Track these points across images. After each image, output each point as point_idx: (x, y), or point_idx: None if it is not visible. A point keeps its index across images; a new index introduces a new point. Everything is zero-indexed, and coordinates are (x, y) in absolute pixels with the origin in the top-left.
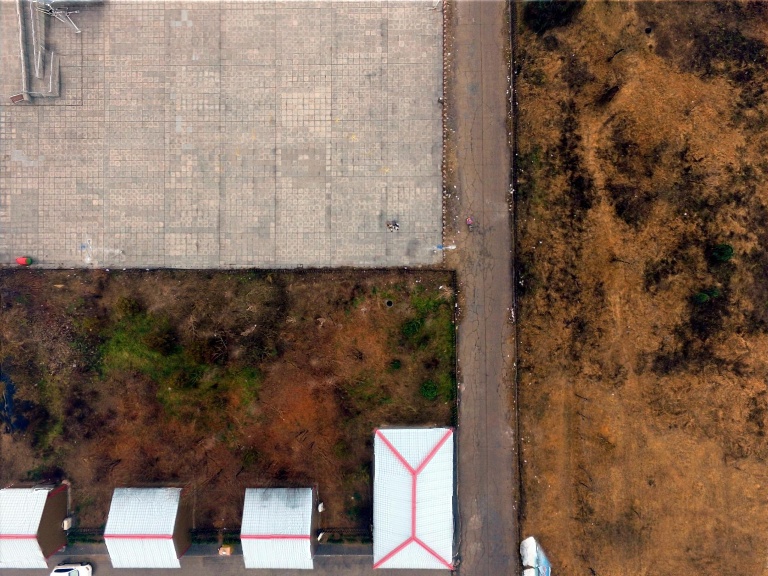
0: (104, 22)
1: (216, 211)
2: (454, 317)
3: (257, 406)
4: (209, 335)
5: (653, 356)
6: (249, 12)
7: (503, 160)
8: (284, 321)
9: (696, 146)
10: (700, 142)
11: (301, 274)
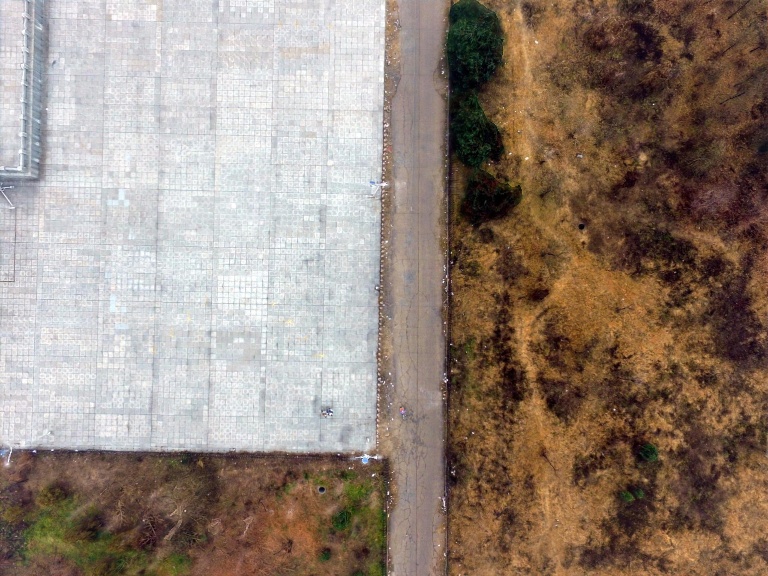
0: (39, 198)
1: (149, 392)
2: (386, 506)
3: None
4: (137, 520)
5: (581, 550)
6: (187, 193)
7: (438, 349)
8: (214, 506)
9: (625, 344)
10: (629, 340)
11: (233, 458)
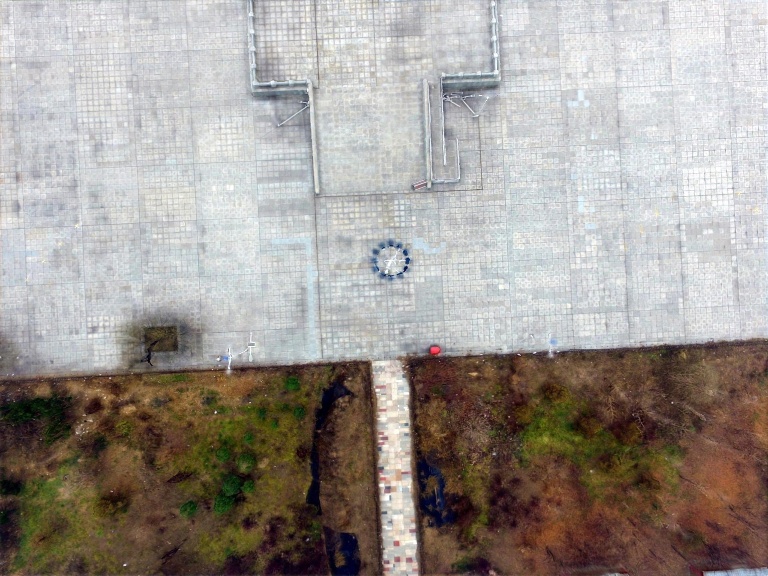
0: (500, 105)
1: (623, 289)
2: None
3: (680, 483)
4: (628, 415)
5: None
6: (646, 89)
7: None
8: (700, 396)
9: None
10: None
11: (712, 348)
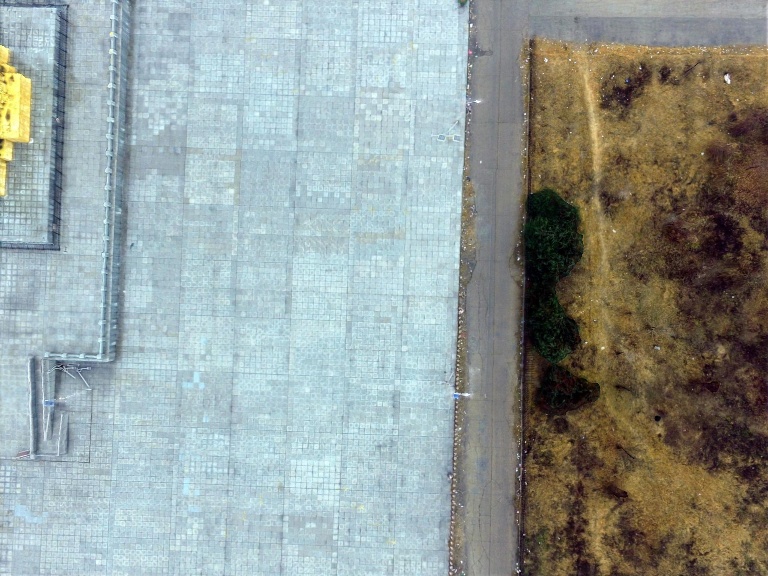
0: (115, 380)
1: (220, 575)
2: None
3: None
4: None
5: None
6: (262, 377)
7: (510, 538)
8: None
9: (702, 540)
10: (706, 536)
11: None
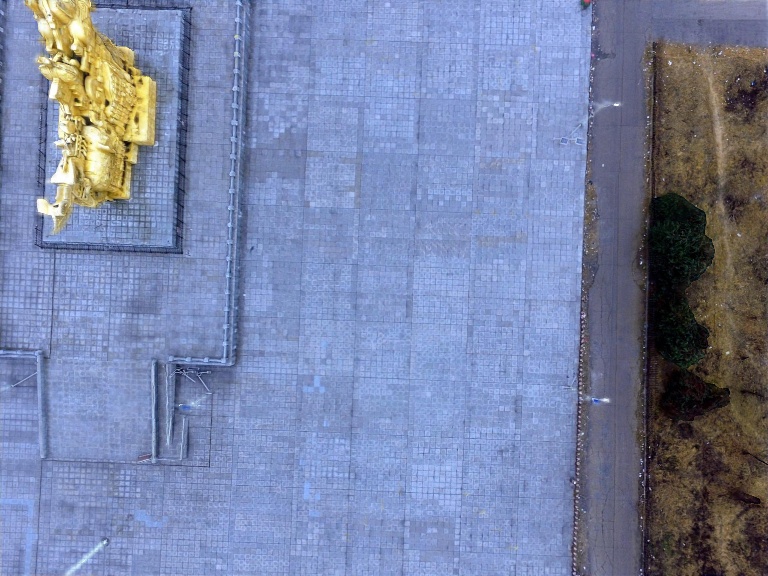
0: (235, 384)
1: None
2: None
3: None
4: None
5: None
6: (383, 381)
7: (634, 544)
8: None
9: None
10: None
11: None
